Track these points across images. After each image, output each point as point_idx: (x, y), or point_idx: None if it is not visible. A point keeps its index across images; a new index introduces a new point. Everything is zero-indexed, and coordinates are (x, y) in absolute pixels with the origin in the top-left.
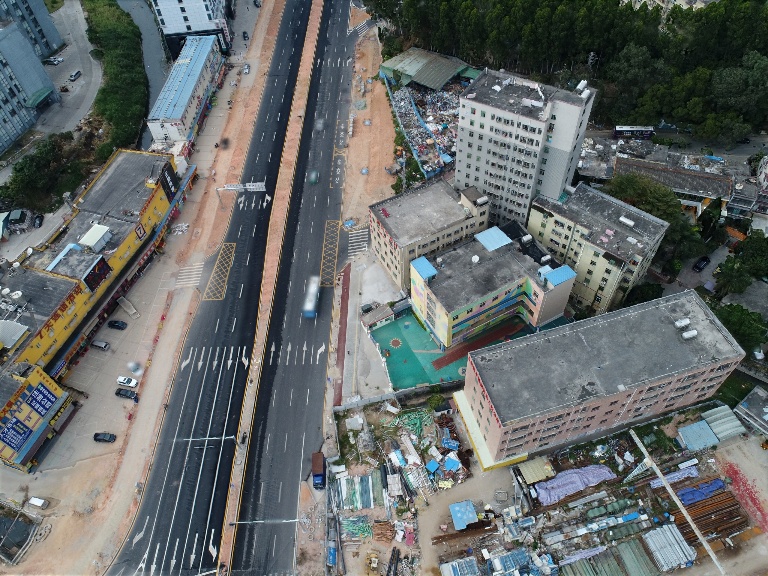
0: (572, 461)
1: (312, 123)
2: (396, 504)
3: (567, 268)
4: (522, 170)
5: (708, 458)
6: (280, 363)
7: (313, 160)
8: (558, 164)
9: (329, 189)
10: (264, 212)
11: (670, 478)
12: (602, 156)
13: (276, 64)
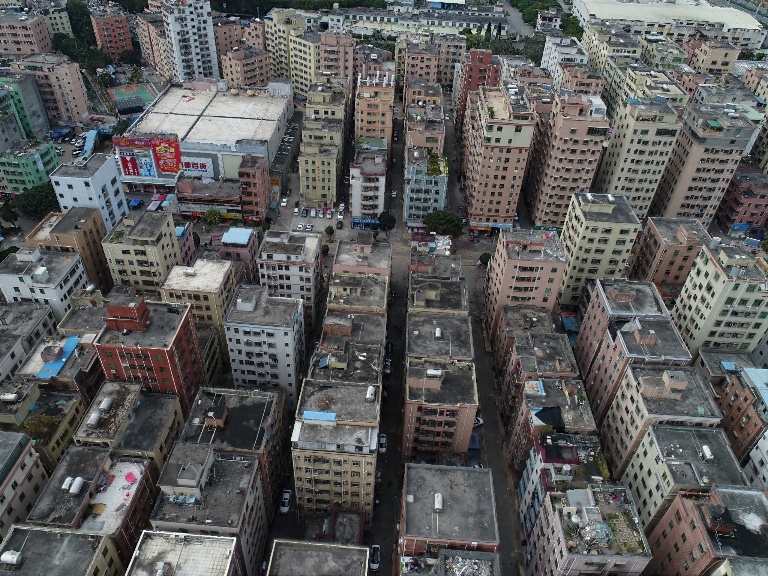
0: None
1: None
2: None
3: None
4: None
5: None
6: None
7: None
8: None
9: None
10: None
11: (4, 68)
12: None
13: None
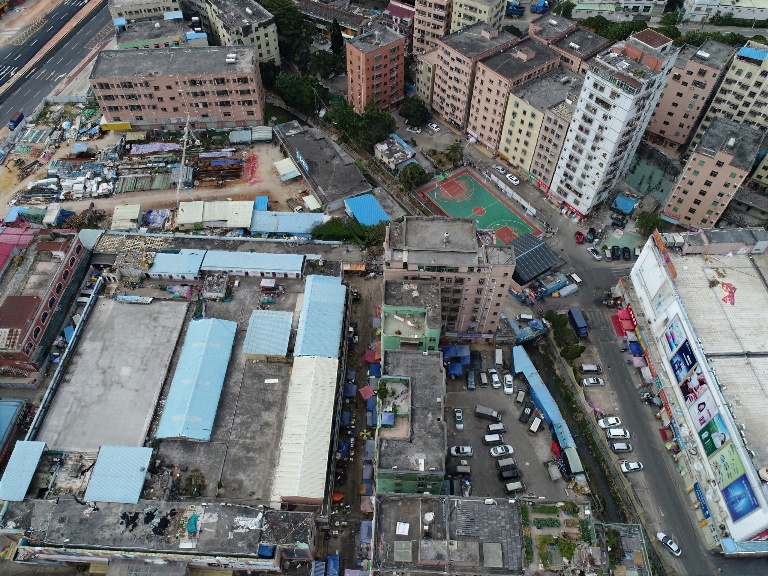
0: (164, 140)
1: None
2: (51, 143)
3: (204, 34)
4: None
5: (244, 151)
6: (32, 78)
7: None
8: None
9: None
10: (78, 8)
11: (212, 154)
12: None
13: None
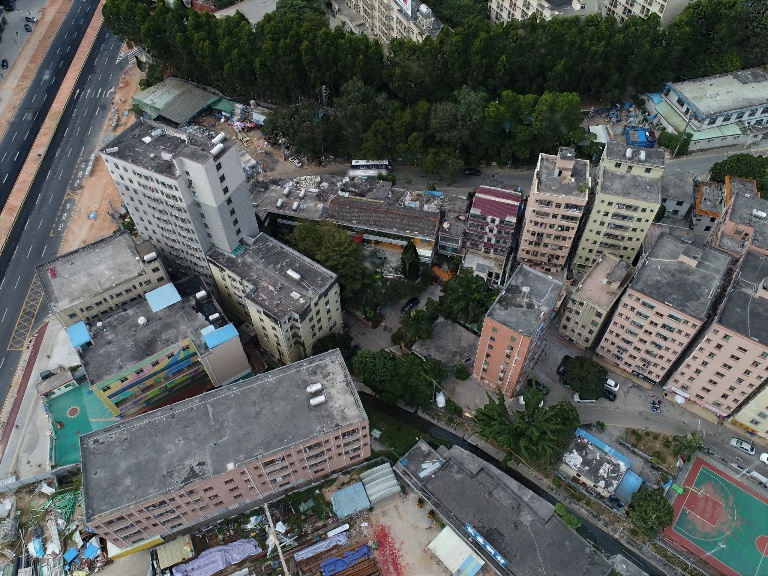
0: (221, 537)
1: (51, 162)
2: None
3: (230, 327)
4: (183, 225)
5: (362, 522)
6: None
7: (40, 204)
8: (214, 219)
9: (49, 237)
10: None
11: (316, 548)
12: (319, 196)
13: (30, 96)
